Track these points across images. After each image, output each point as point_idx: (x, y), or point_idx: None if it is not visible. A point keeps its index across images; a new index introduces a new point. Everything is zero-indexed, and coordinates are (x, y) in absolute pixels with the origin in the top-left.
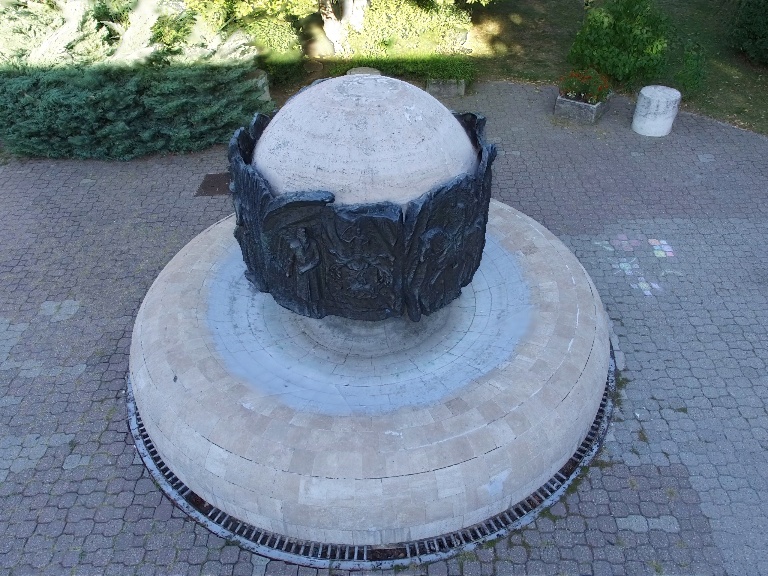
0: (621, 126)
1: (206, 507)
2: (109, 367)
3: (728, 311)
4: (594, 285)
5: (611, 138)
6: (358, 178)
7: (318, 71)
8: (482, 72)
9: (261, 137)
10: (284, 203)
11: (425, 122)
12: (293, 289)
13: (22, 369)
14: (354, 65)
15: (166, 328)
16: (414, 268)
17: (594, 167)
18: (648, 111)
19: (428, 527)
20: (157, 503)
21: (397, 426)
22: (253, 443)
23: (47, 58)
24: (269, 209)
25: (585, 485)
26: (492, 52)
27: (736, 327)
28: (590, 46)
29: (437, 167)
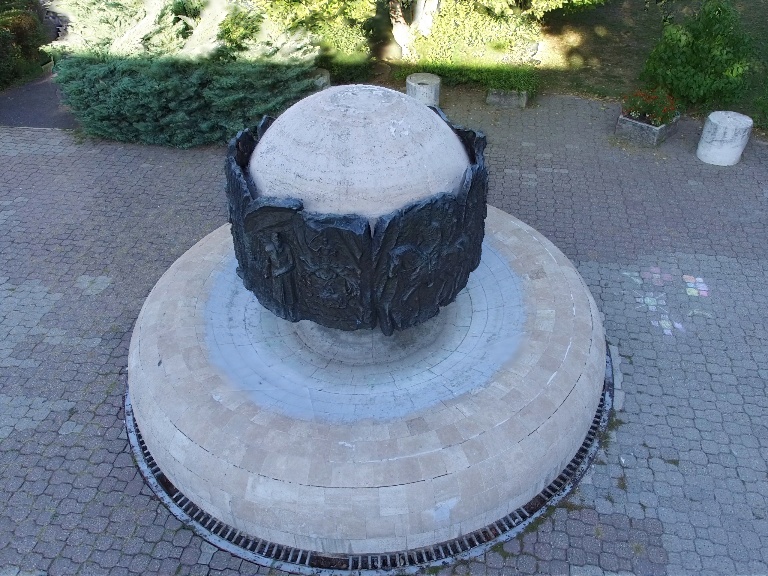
0: (685, 151)
1: (175, 489)
2: (120, 343)
3: (753, 362)
4: (599, 318)
5: (670, 163)
6: (333, 188)
7: (386, 73)
8: (550, 84)
9: (260, 140)
10: (258, 207)
11: (411, 137)
12: (272, 290)
13: (47, 336)
14: (419, 70)
15: (164, 314)
16: (383, 283)
17: (644, 193)
18: (714, 138)
19: (369, 543)
20: (130, 478)
21: (352, 438)
22: (213, 435)
23: (124, 48)
24: (247, 211)
25: (547, 525)
26: (566, 64)
27: (758, 380)
28: (664, 64)
29: (417, 184)
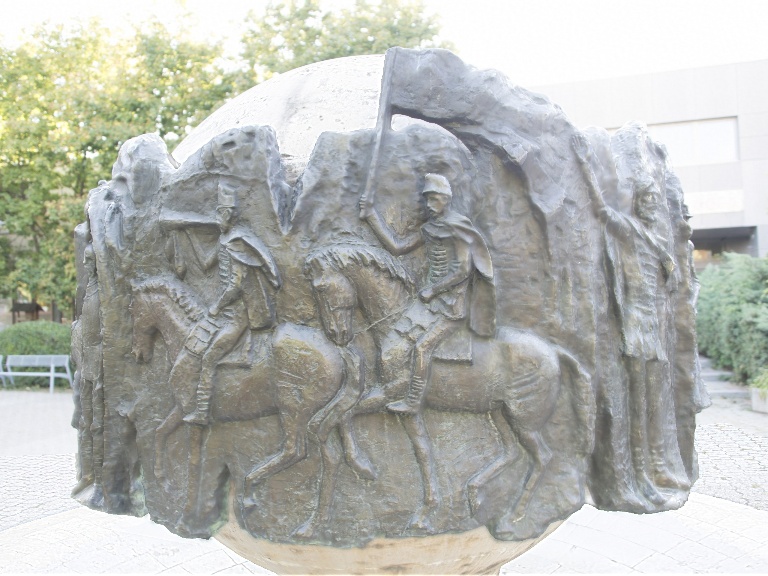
0: None
1: None
2: None
3: None
4: None
5: None
6: None
7: None
8: None
9: None
10: None
11: None
12: None
13: None
14: None
15: None
16: None
17: None
18: None
19: None
20: None
21: None
22: None
23: None
24: None
25: None
26: None
27: None
28: None
29: None
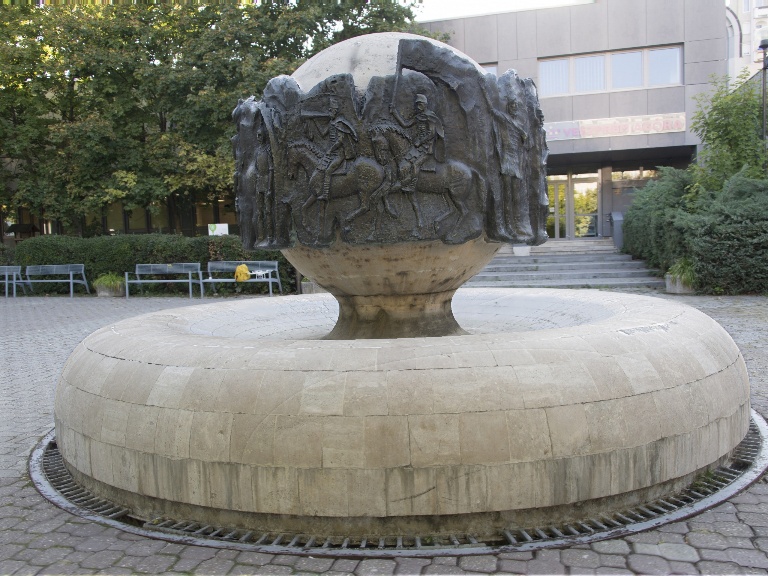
0: None
1: None
2: None
3: None
4: None
5: None
6: None
7: None
8: None
9: None
10: None
11: None
12: None
13: None
14: None
15: None
16: None
17: None
18: None
19: None
20: None
21: None
22: None
23: None
24: None
25: None
26: None
27: None
28: None
29: None
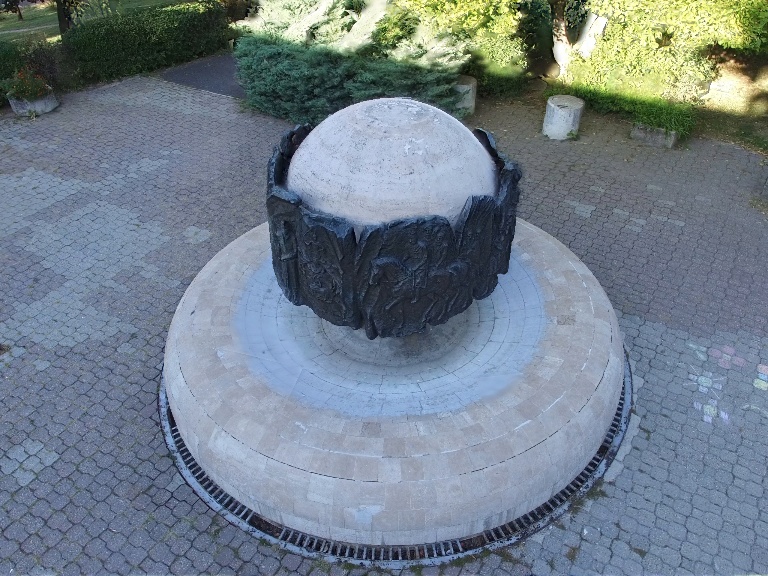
0: None
1: None
2: None
3: None
4: (614, 381)
5: None
6: (337, 191)
7: (541, 90)
8: (712, 128)
9: None
10: (270, 194)
11: (424, 157)
12: None
13: (144, 269)
14: (571, 92)
15: (217, 272)
16: (365, 288)
17: (760, 265)
18: None
19: (297, 520)
20: (149, 402)
21: (309, 422)
22: (202, 384)
23: (294, 33)
24: None
25: (474, 566)
26: (745, 109)
27: None
28: None
29: (416, 202)
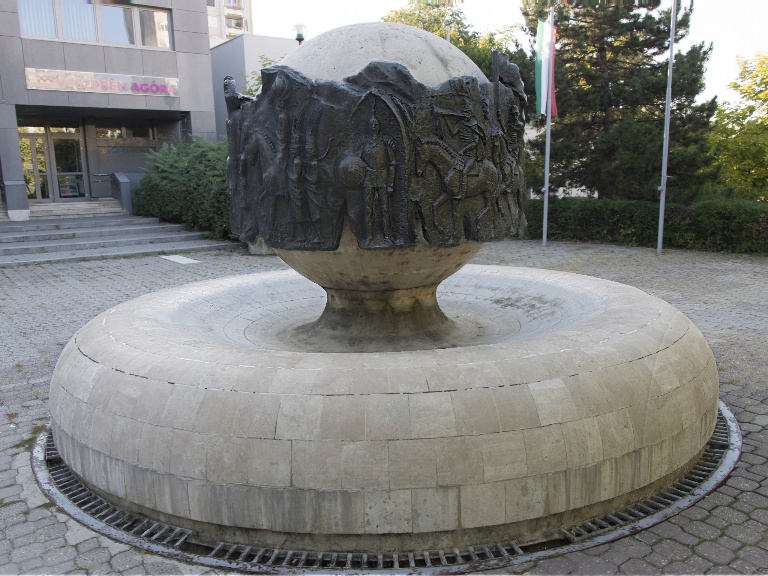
0: None
1: None
2: None
3: None
4: None
5: None
6: None
7: None
8: None
9: None
10: None
11: None
12: None
13: None
14: None
15: None
16: None
17: None
18: None
19: None
20: None
21: (252, 276)
22: None
23: None
24: None
25: None
26: None
27: None
28: None
29: None
